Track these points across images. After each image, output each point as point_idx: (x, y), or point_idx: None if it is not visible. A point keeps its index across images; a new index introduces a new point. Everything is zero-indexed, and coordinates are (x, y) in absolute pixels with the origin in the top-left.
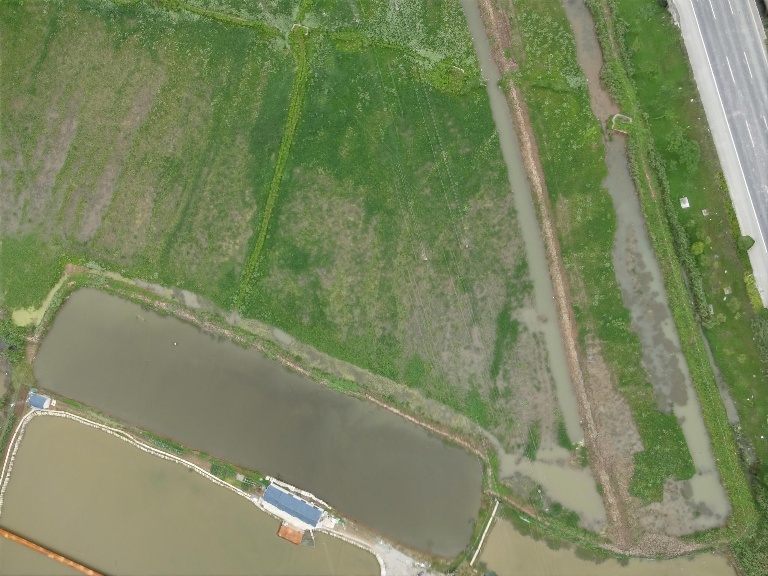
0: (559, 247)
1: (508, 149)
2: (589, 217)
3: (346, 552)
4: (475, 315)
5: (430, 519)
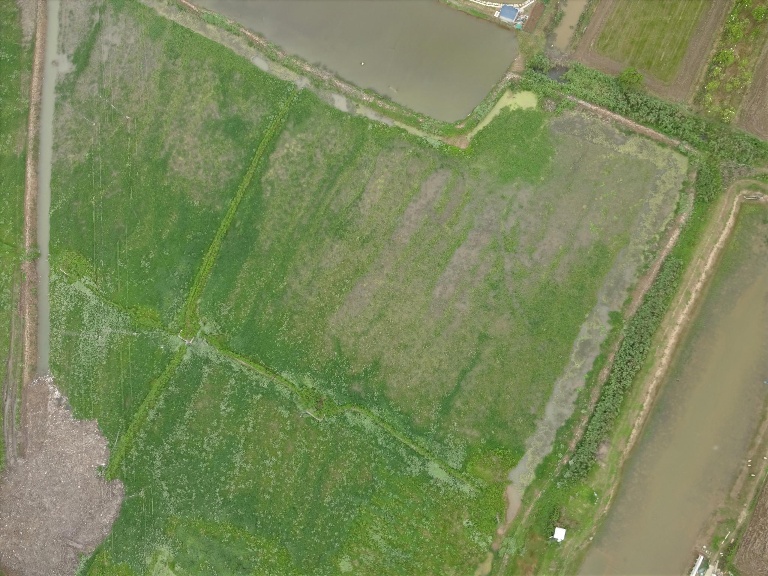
0: None
1: (46, 199)
2: (2, 136)
3: None
4: (102, 70)
5: None
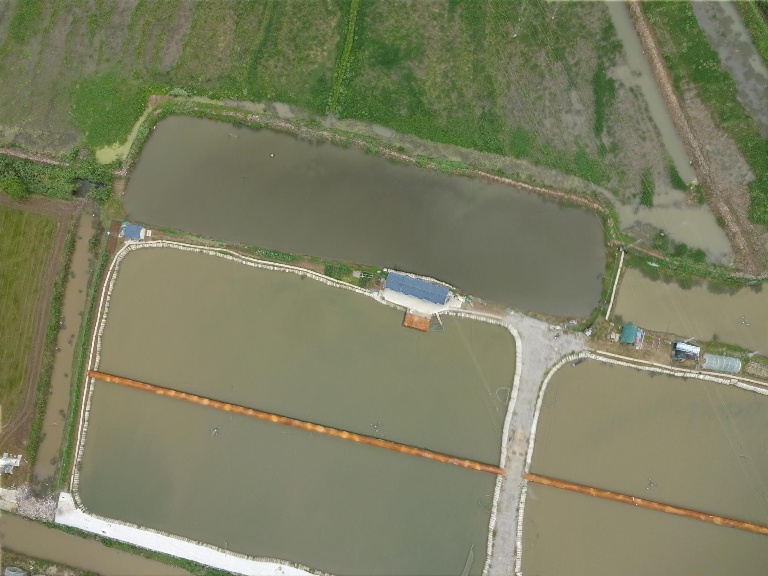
0: (641, 5)
1: None
2: None
3: (477, 330)
4: (571, 79)
5: (556, 285)
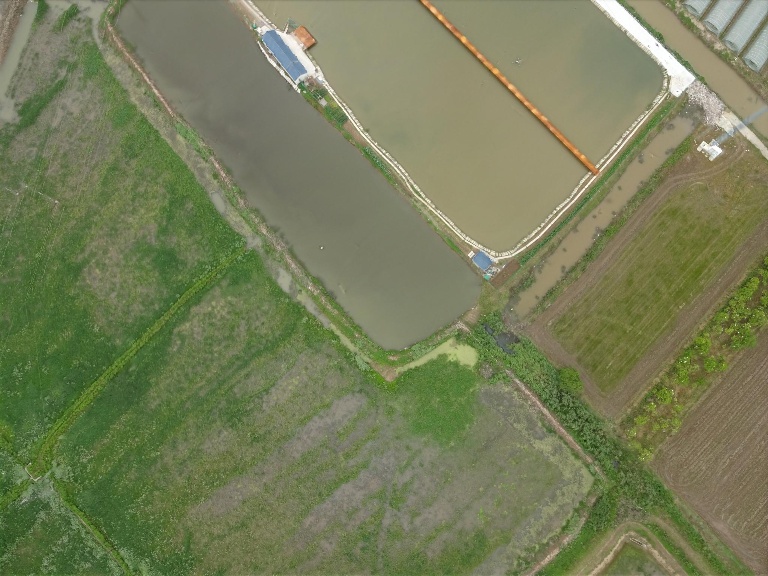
0: None
1: None
2: None
3: (266, 3)
4: (47, 136)
5: None
